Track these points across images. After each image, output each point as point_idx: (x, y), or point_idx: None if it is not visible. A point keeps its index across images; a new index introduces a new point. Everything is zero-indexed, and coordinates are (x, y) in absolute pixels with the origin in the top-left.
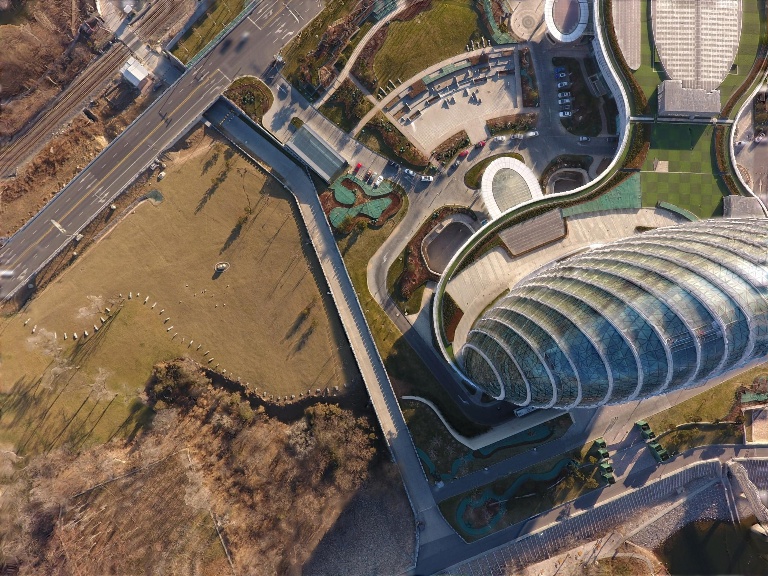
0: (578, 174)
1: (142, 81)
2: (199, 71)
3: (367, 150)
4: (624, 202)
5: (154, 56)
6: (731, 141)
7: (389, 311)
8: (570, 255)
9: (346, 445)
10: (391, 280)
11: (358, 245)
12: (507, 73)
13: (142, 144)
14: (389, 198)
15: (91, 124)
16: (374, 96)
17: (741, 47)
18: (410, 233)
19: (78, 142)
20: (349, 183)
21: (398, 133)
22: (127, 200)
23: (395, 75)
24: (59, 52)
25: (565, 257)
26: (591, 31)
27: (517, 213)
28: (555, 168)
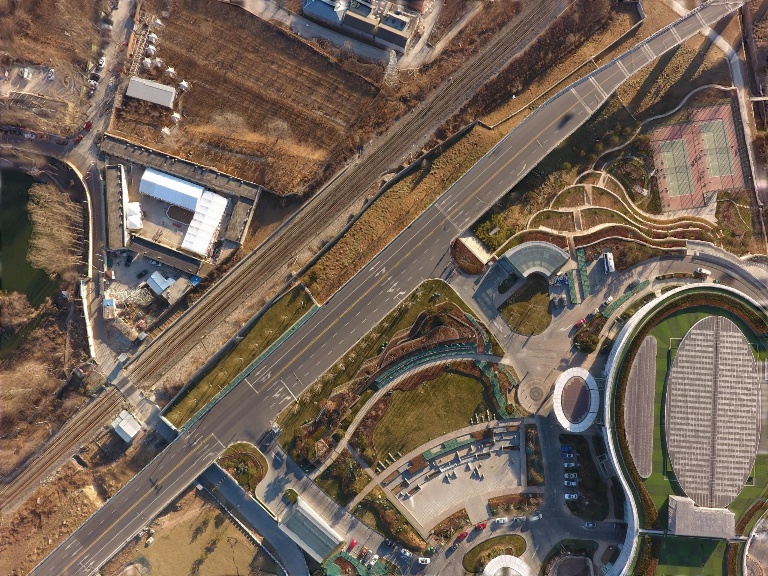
0: None
1: (134, 435)
2: (192, 435)
3: (363, 525)
4: None
5: (147, 404)
6: (744, 560)
7: None
8: None
9: None
10: None
11: None
12: (512, 449)
13: (131, 511)
14: None
15: (80, 471)
16: (372, 469)
17: (758, 456)
18: None
19: (66, 493)
20: (343, 562)
21: (396, 511)
22: (113, 566)
23: (395, 448)
24: (51, 389)
25: None
26: (601, 420)
27: None
28: (558, 558)
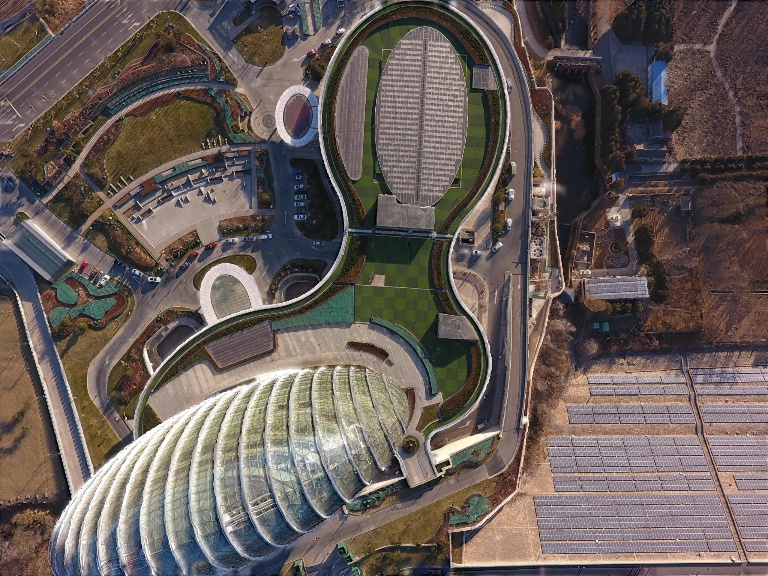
0: (315, 277)
1: None
2: None
3: (95, 248)
4: (336, 316)
5: None
6: (449, 257)
7: (108, 415)
8: (232, 387)
9: (36, 561)
10: (112, 383)
11: (78, 346)
12: (244, 173)
13: None
14: (114, 298)
15: None
16: (104, 192)
17: (465, 160)
18: (134, 335)
19: None
20: (73, 282)
21: (126, 232)
22: None
23: (127, 172)
24: None
25: (227, 388)
26: None
27: (226, 324)
28: (284, 273)
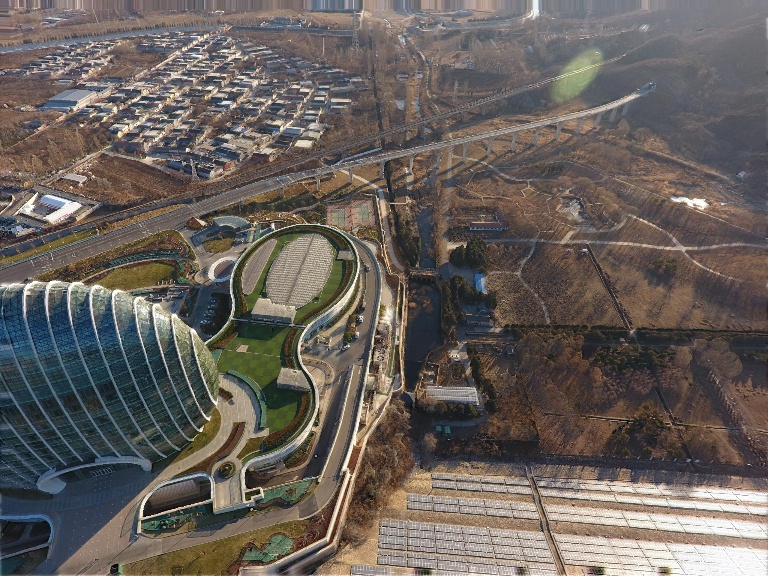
0: None
1: None
2: None
3: None
4: None
5: None
6: (300, 337)
7: None
8: None
9: None
10: None
11: None
12: (178, 298)
13: None
14: None
15: None
16: None
17: (325, 290)
18: None
19: None
20: None
21: None
22: None
23: None
24: None
25: None
26: None
27: None
28: None
